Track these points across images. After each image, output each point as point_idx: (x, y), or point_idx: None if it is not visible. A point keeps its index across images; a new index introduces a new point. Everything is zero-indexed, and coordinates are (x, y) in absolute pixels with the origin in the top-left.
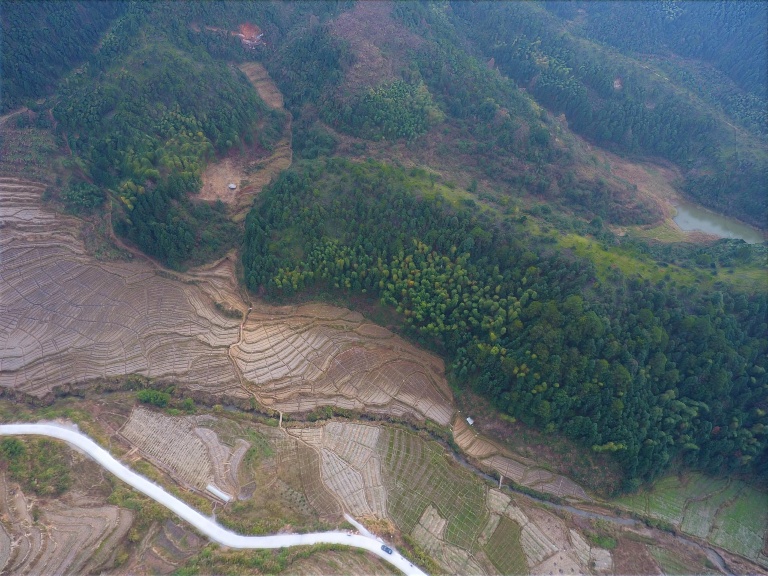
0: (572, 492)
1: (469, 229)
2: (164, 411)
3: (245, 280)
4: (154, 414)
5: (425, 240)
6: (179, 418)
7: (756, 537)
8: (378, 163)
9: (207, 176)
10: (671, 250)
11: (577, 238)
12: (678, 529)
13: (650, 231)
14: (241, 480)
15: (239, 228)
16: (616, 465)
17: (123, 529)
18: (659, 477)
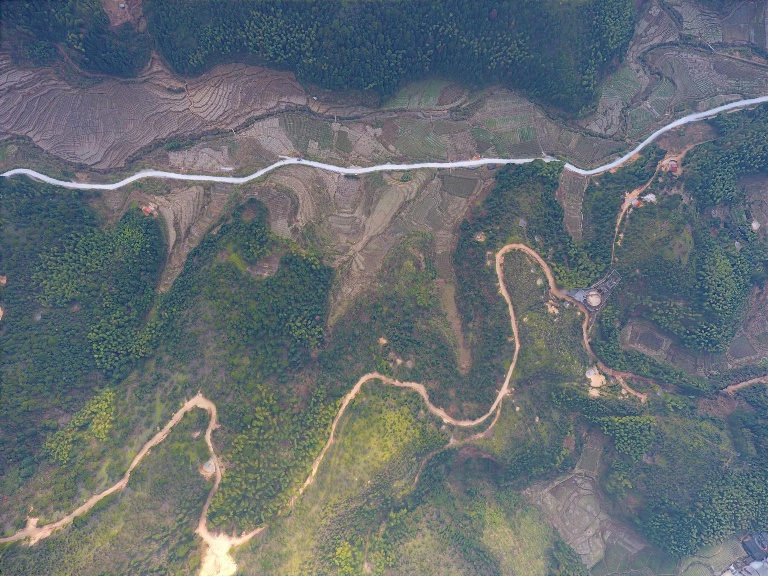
0: (364, 111)
1: None
2: (182, 149)
3: (174, 69)
4: (178, 152)
5: (256, 8)
6: (190, 149)
7: (436, 100)
8: None
9: (103, 5)
10: None
11: None
12: (407, 109)
13: None
14: (233, 161)
15: (147, 36)
16: (377, 93)
17: (202, 192)
18: (397, 90)
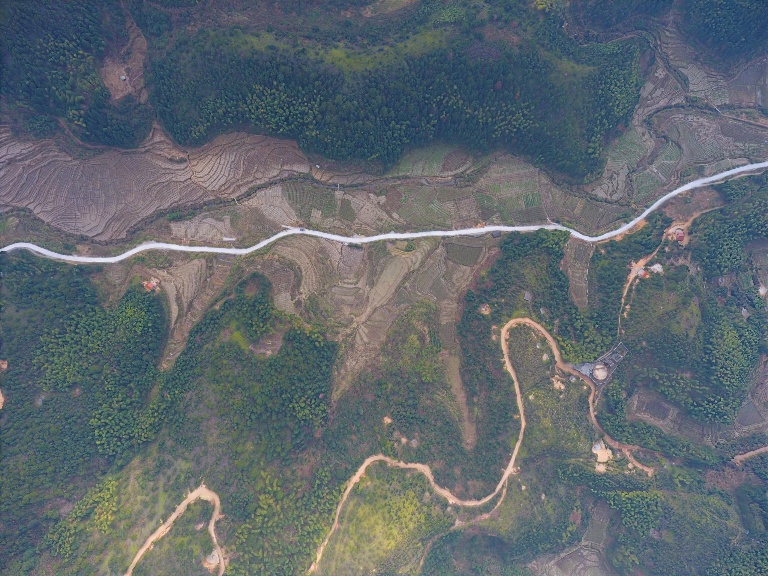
0: (368, 179)
1: (278, 66)
2: (183, 219)
3: (176, 141)
4: (180, 222)
5: (258, 82)
6: (192, 219)
7: (440, 166)
8: (205, 30)
9: (104, 79)
10: (390, 28)
11: (334, 53)
12: (410, 176)
13: (385, 3)
14: (235, 231)
15: (148, 107)
16: (381, 161)
17: (204, 264)
18: (401, 158)
